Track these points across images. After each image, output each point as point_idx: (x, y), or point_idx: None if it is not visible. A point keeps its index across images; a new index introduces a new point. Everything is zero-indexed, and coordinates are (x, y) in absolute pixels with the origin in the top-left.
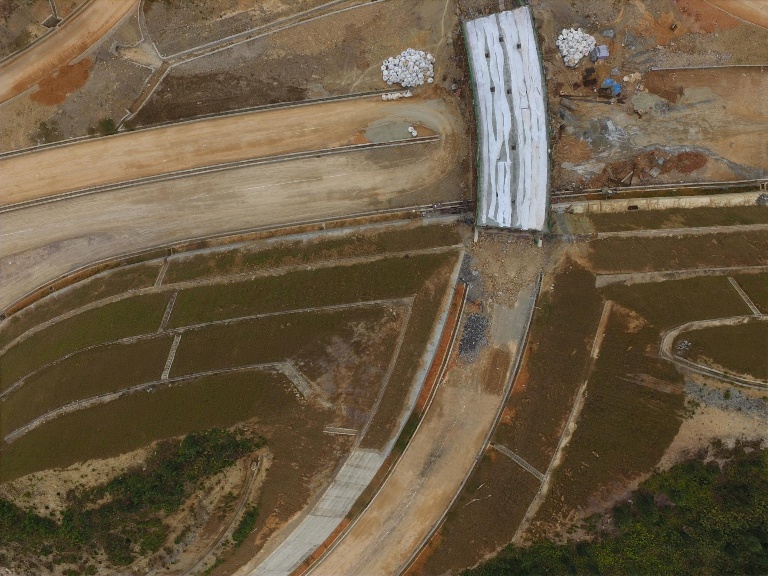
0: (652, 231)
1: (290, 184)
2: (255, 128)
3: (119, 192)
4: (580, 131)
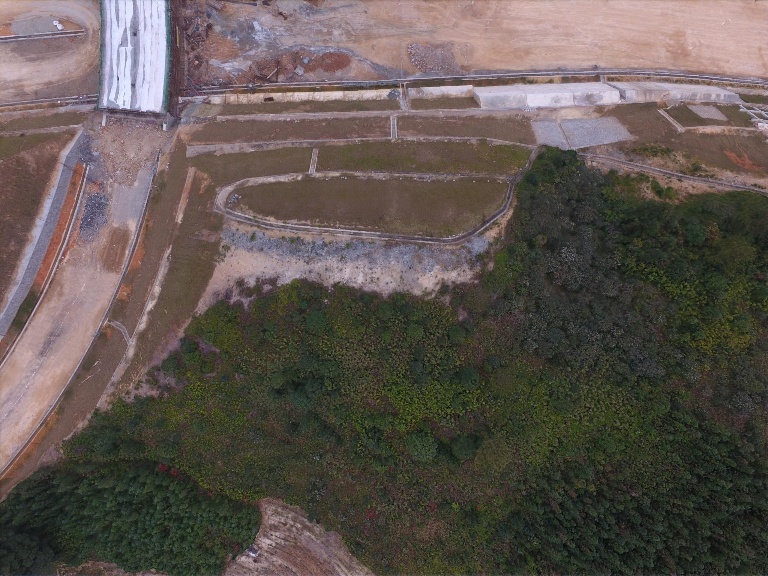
0: (270, 115)
1: None
2: None
3: None
4: (227, 30)
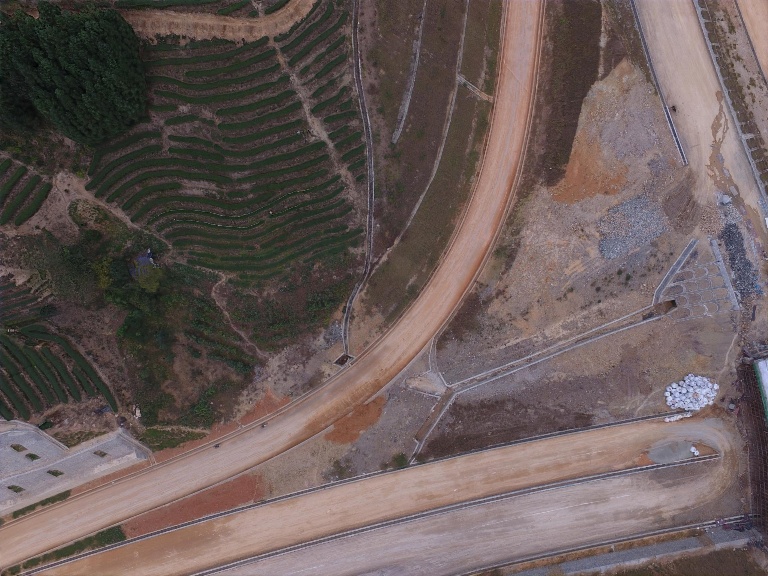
0: None
1: (578, 507)
2: (543, 454)
3: (411, 523)
4: None
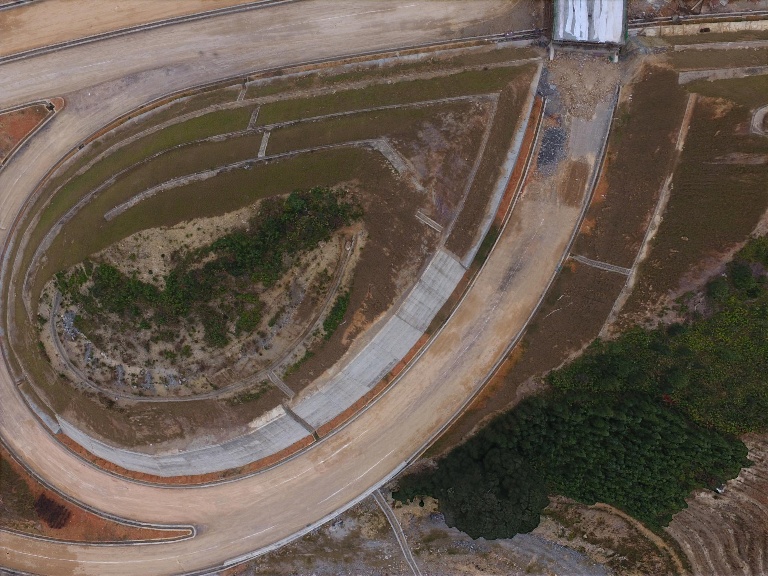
0: (728, 43)
1: (364, 15)
2: None
3: (196, 24)
4: None
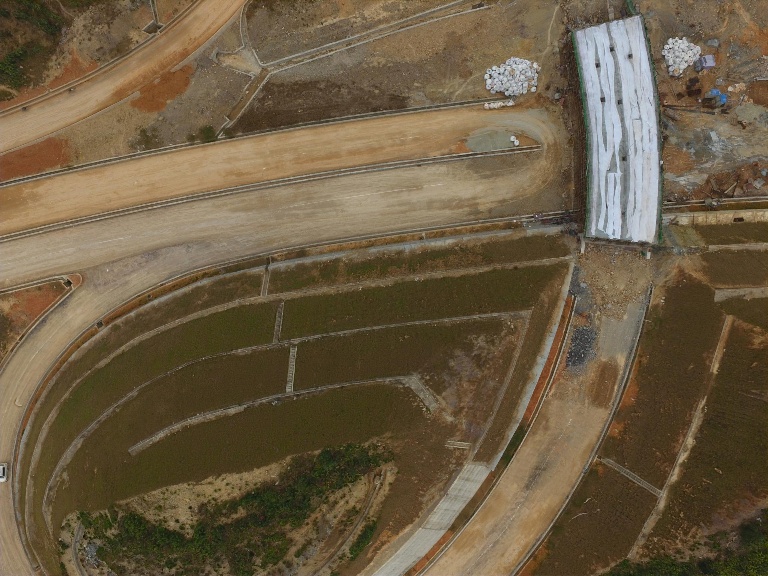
0: (763, 244)
1: (390, 193)
2: (355, 136)
3: (218, 200)
4: (683, 141)
